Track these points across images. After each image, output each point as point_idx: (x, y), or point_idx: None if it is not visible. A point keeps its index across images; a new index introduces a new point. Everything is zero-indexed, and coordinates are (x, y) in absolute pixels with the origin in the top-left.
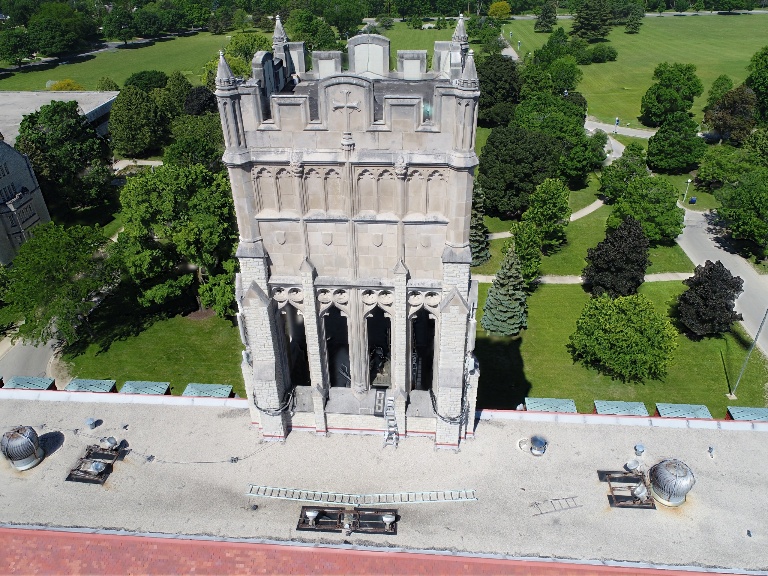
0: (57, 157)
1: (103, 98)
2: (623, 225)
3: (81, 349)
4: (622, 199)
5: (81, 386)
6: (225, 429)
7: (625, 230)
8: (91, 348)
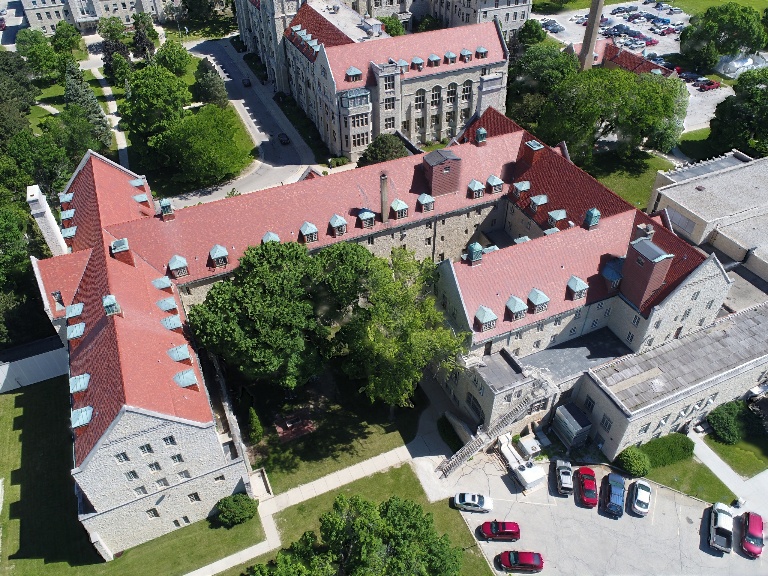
0: (18, 220)
1: None
2: (107, 43)
3: (229, 174)
4: (42, 63)
5: (308, 34)
6: None
7: (112, 43)
8: None
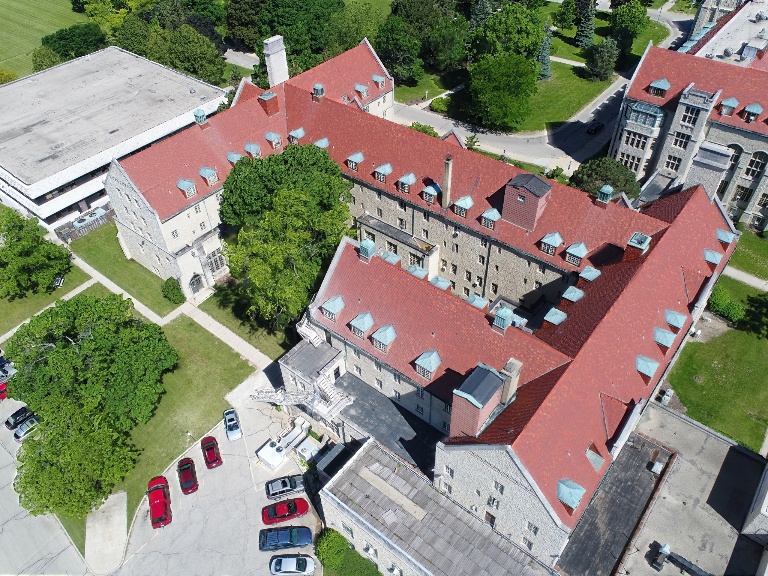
0: None
1: (116, 56)
2: None
3: (510, 127)
4: None
5: None
6: (757, 6)
7: None
8: (512, 125)
